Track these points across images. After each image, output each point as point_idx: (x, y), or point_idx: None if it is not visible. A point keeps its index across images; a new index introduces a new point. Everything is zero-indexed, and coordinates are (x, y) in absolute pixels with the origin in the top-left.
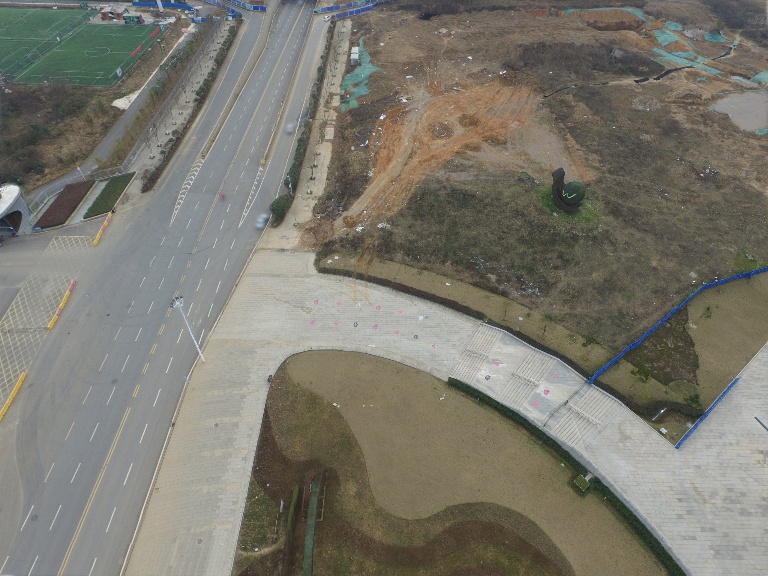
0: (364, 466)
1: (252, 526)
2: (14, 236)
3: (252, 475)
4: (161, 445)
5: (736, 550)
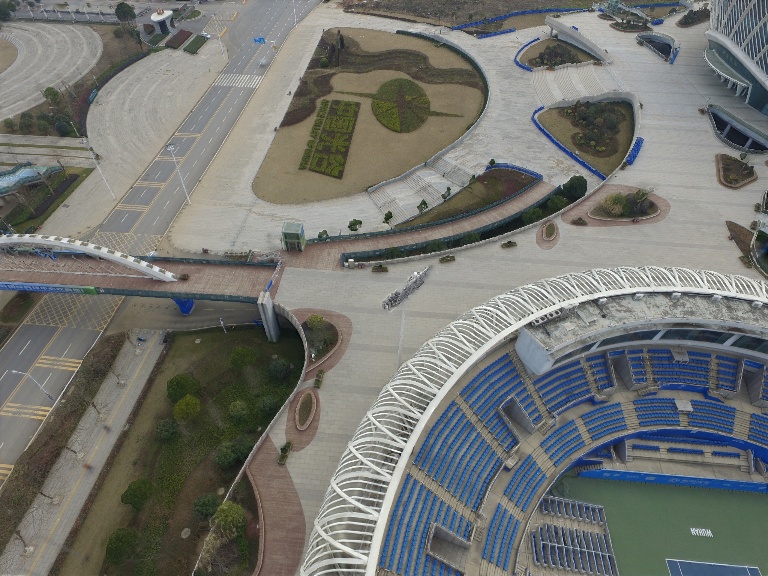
0: (359, 45)
1: (318, 53)
2: (207, 1)
3: (317, 46)
4: (283, 42)
5: None
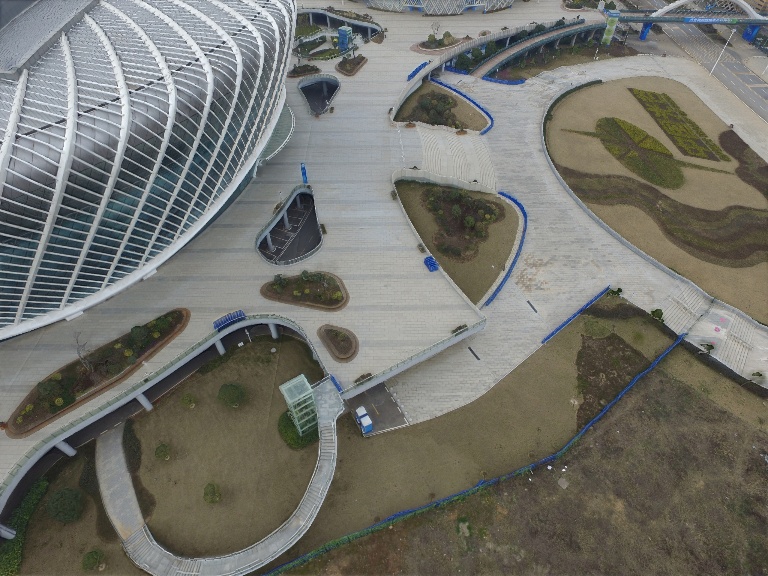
0: None
1: None
2: None
3: None
4: None
5: (578, 241)
